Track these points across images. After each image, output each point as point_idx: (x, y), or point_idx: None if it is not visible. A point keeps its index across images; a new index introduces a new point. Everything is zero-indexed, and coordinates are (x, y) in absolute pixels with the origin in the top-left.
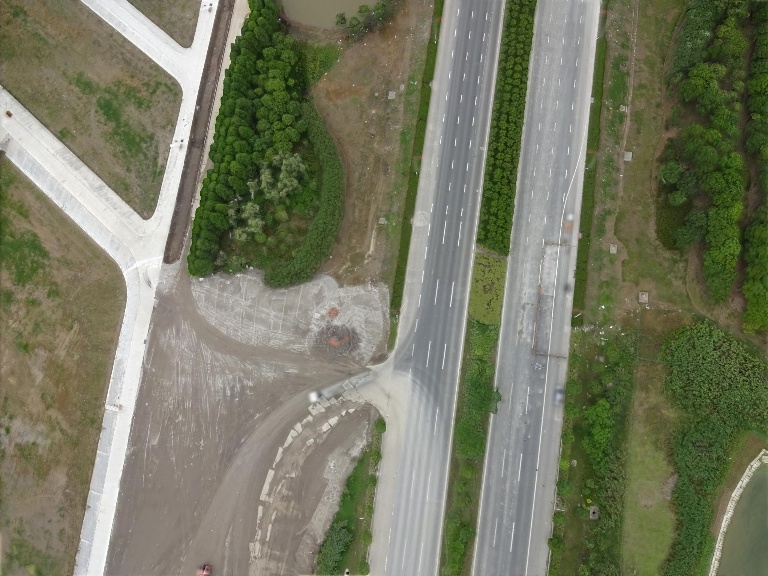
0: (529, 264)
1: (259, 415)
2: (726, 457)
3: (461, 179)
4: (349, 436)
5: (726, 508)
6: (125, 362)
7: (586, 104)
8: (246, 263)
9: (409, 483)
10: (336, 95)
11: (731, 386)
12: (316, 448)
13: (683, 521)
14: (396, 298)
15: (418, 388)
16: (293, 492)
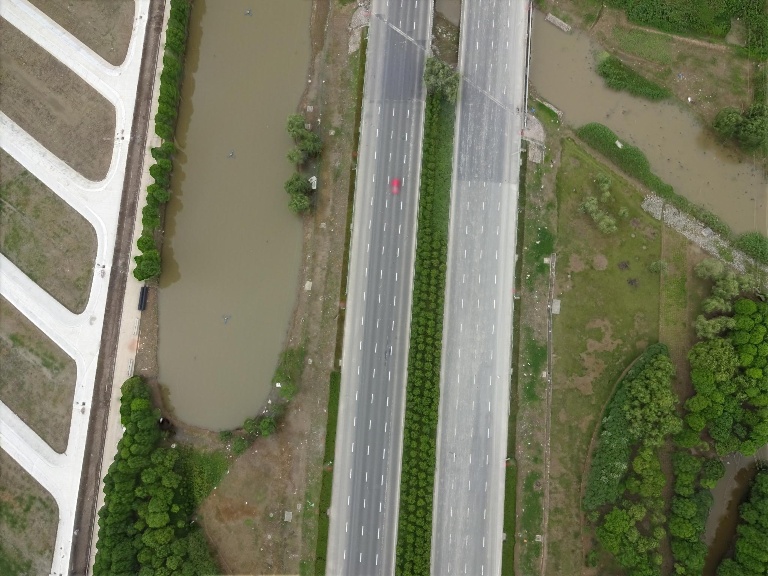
0: None
1: None
2: None
3: None
4: None
5: None
6: None
7: (498, 540)
8: None
9: None
10: (227, 515)
11: None
12: None
13: None
14: None
15: None
16: None
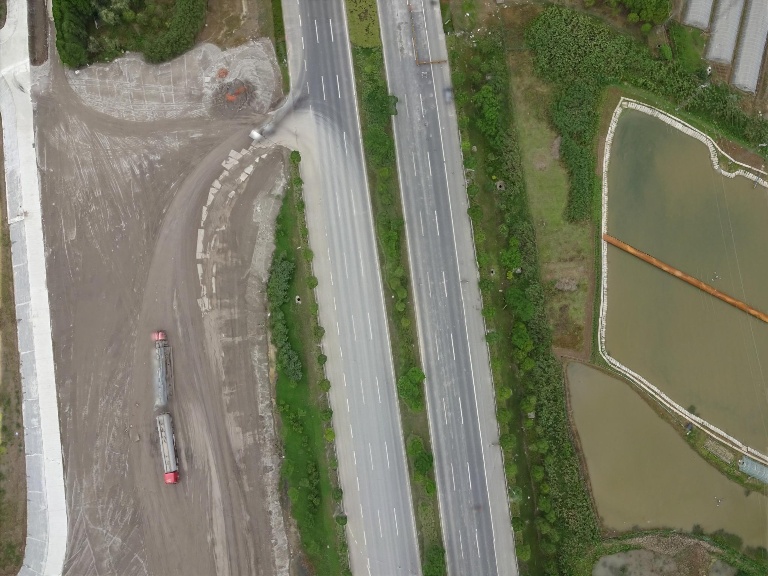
0: None
1: (174, 183)
2: (595, 111)
3: None
4: (268, 178)
5: (603, 152)
6: (17, 171)
7: None
8: (121, 47)
9: (335, 204)
10: None
11: (586, 53)
12: (239, 198)
13: (573, 171)
14: (280, 44)
15: (321, 120)
16: (227, 243)
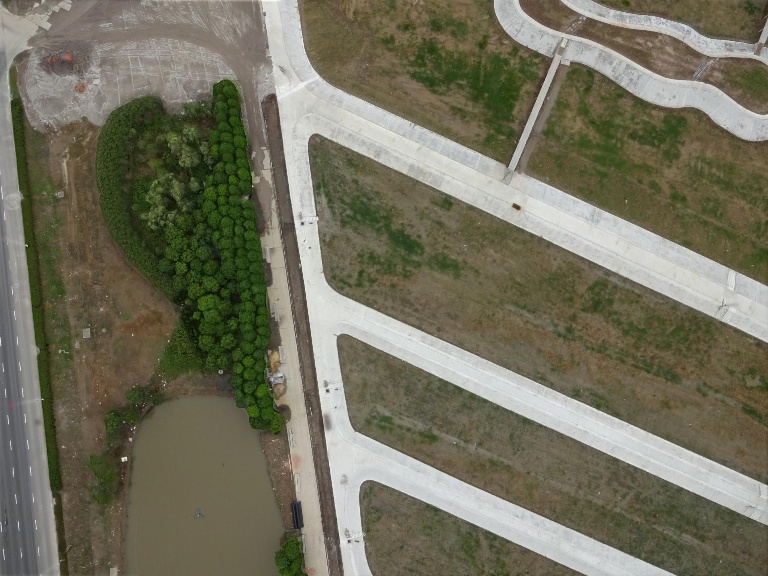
0: None
1: None
2: None
3: None
4: None
5: None
6: None
7: None
8: None
9: None
10: (149, 319)
11: None
12: None
13: None
14: (17, 116)
15: None
16: None
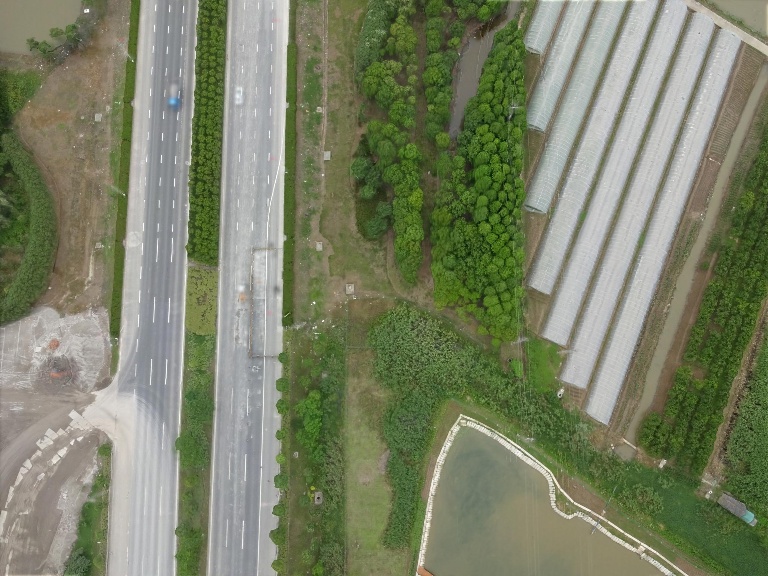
0: (240, 271)
1: None
2: (430, 427)
3: (169, 195)
4: (79, 464)
5: (433, 473)
6: None
7: (282, 109)
8: None
9: (142, 500)
10: (41, 122)
11: (429, 361)
12: (47, 481)
13: (396, 492)
14: (114, 321)
15: (143, 406)
16: (28, 529)
